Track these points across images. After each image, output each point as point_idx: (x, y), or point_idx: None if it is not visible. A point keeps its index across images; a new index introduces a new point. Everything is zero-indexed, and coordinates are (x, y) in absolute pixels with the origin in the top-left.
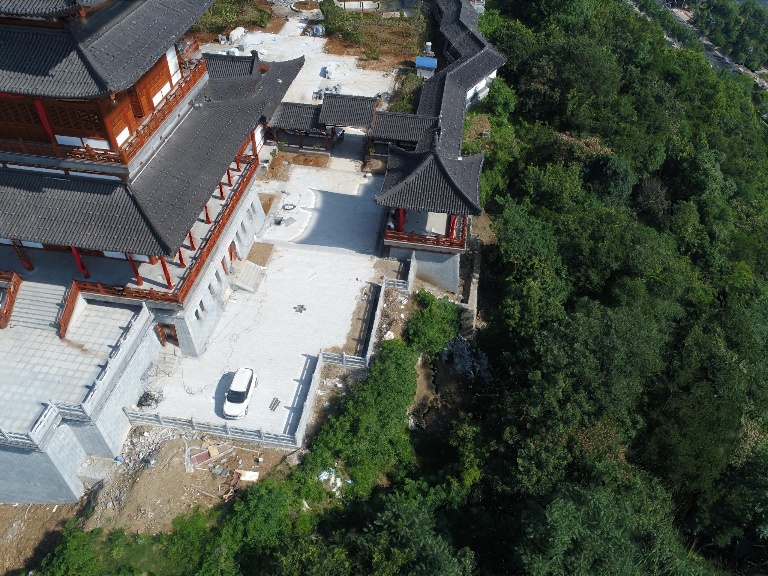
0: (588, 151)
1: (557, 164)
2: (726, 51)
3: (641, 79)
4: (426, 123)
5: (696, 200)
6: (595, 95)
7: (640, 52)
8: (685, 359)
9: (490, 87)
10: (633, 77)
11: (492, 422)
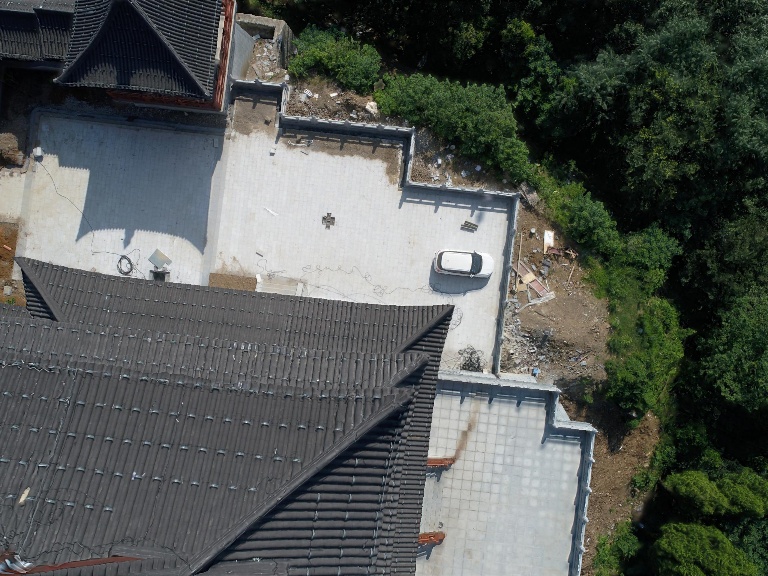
0: None
1: None
2: None
3: None
4: None
5: None
6: None
7: None
8: None
9: None
10: None
11: (461, 6)
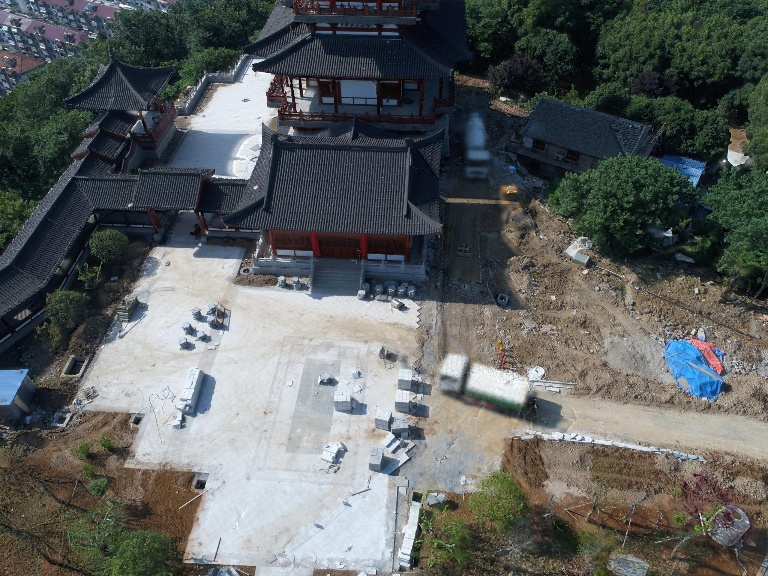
0: None
1: None
2: None
3: None
4: None
5: None
6: None
7: None
8: (3, 115)
9: None
10: None
11: None
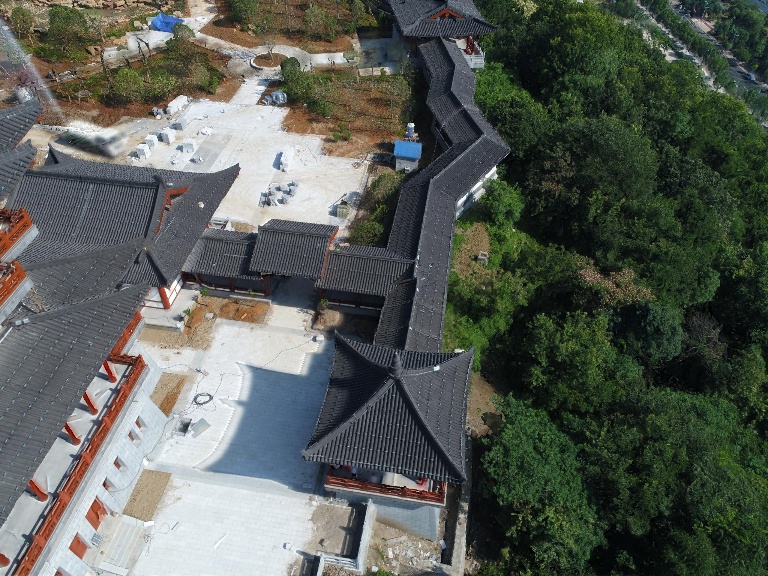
0: (620, 297)
1: (578, 314)
2: (752, 67)
3: (680, 161)
4: (397, 268)
5: (759, 339)
6: (625, 198)
7: (678, 124)
8: None
9: (488, 192)
10: (670, 159)
11: None
